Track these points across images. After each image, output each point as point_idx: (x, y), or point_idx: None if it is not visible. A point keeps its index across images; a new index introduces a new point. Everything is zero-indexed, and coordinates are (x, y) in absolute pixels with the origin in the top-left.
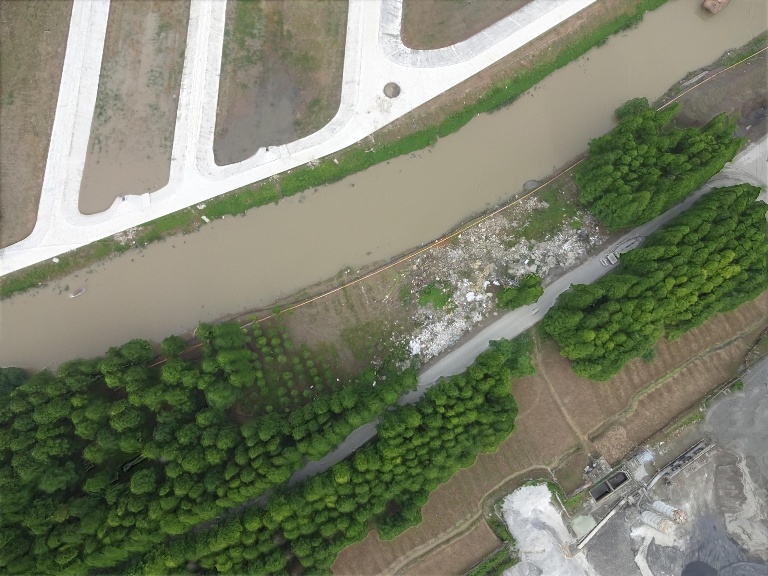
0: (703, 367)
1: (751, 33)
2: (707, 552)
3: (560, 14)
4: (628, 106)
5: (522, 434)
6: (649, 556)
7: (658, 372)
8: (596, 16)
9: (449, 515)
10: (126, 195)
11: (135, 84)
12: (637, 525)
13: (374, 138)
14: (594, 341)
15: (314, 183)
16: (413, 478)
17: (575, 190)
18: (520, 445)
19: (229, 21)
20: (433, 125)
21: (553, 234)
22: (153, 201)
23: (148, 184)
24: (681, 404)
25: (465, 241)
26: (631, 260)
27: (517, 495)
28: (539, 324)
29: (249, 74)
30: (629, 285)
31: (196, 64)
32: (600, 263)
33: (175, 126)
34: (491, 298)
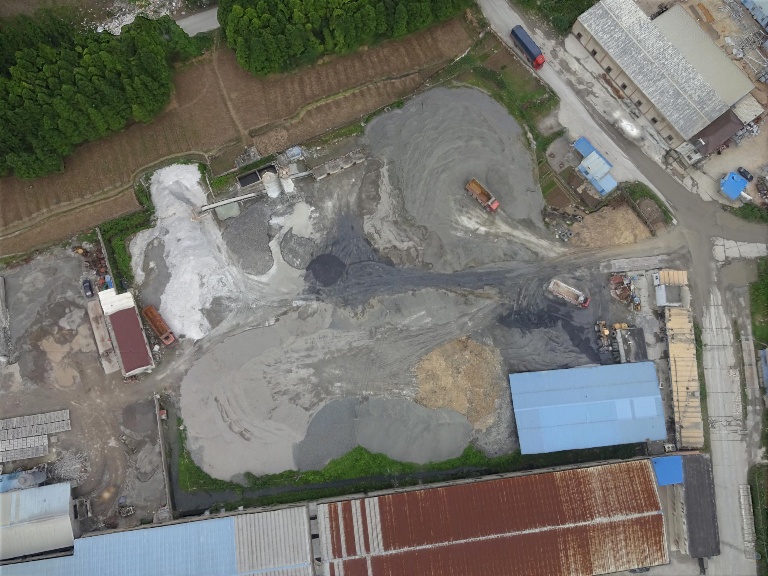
0: (375, 91)
1: None
2: (340, 248)
3: None
4: None
5: (187, 121)
6: (283, 242)
7: (331, 89)
8: None
9: (100, 180)
10: None
11: None
12: (278, 214)
13: None
14: (242, 18)
15: None
16: (42, 108)
17: None
18: (183, 131)
19: None
20: None
21: None
22: None
23: None
24: (346, 119)
25: None
26: None
27: (166, 169)
28: None
29: None
30: None
31: None
32: None
33: None
34: None
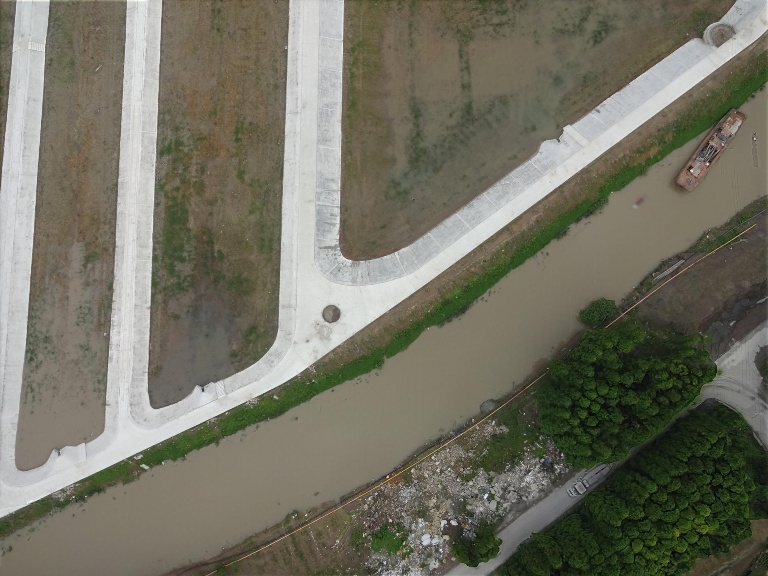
0: None
1: (734, 207)
2: None
3: (513, 210)
4: (593, 312)
5: None
6: None
7: None
8: (554, 208)
9: None
10: (61, 449)
11: (64, 323)
12: None
13: (315, 369)
14: None
15: (255, 421)
16: None
17: (537, 410)
18: None
19: (157, 245)
20: (378, 348)
21: (514, 463)
22: (89, 455)
23: (84, 433)
24: None
25: (418, 477)
26: (595, 512)
27: None
28: (501, 569)
29: (181, 303)
30: (590, 555)
31: (124, 300)
32: (567, 494)
33: (107, 367)
34: (448, 542)
